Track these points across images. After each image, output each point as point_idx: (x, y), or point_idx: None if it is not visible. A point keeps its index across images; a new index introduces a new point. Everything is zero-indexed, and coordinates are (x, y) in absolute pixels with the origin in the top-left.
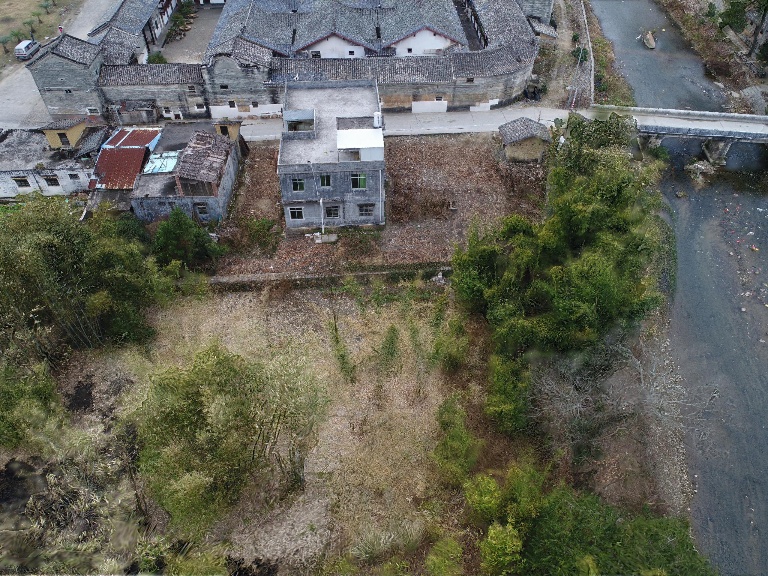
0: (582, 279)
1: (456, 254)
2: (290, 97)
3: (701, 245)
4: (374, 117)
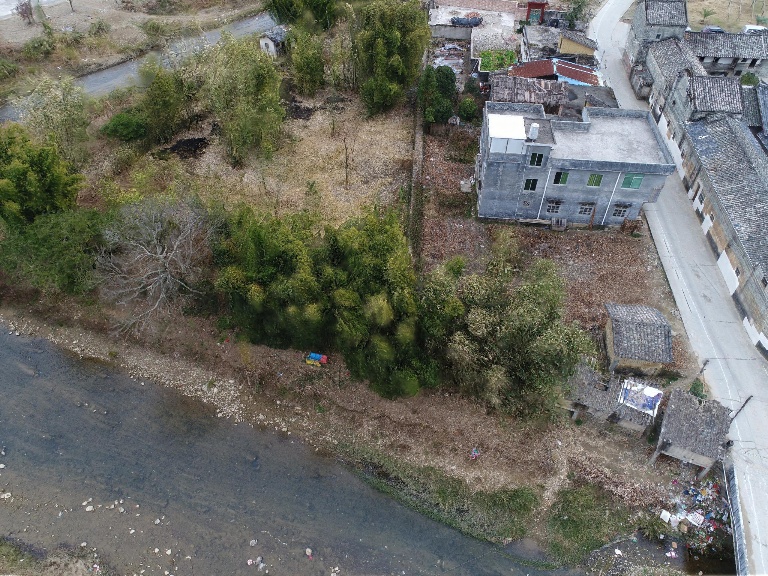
0: None
1: None
2: (629, 119)
3: (454, 574)
4: None
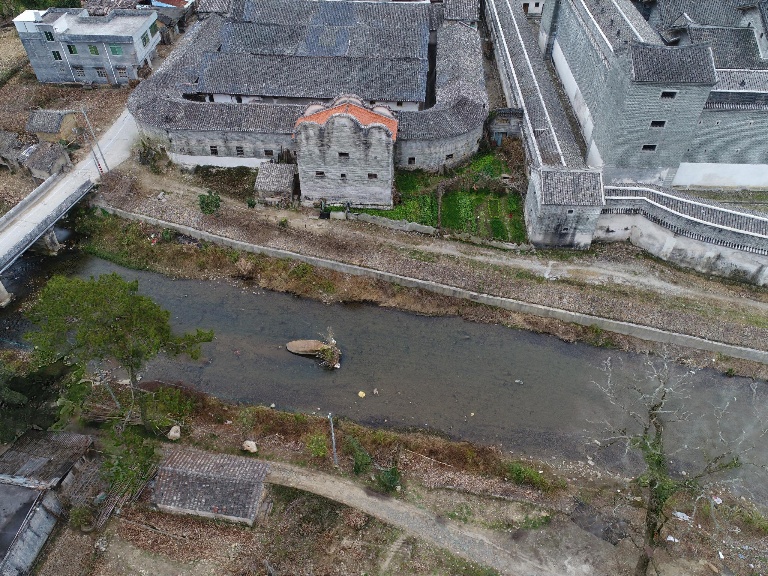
0: None
1: None
2: (144, 17)
3: None
4: None
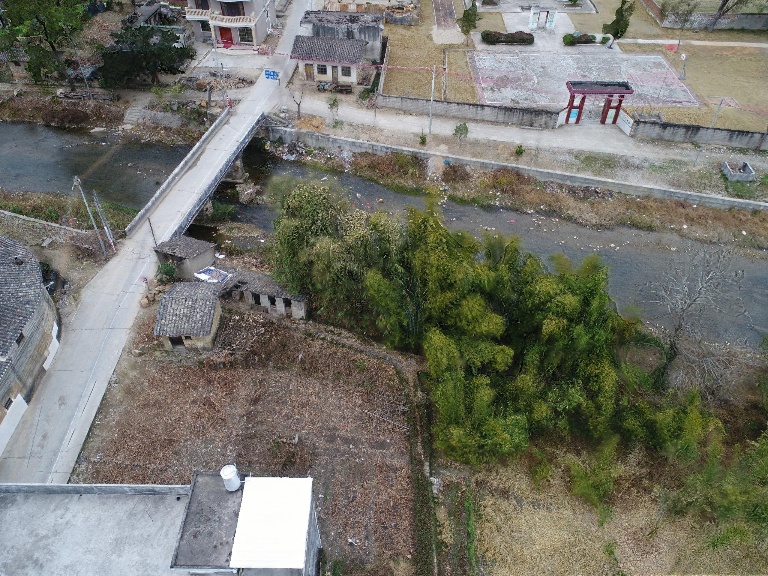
0: (580, 304)
1: (466, 437)
2: None
3: None
4: (231, 481)
